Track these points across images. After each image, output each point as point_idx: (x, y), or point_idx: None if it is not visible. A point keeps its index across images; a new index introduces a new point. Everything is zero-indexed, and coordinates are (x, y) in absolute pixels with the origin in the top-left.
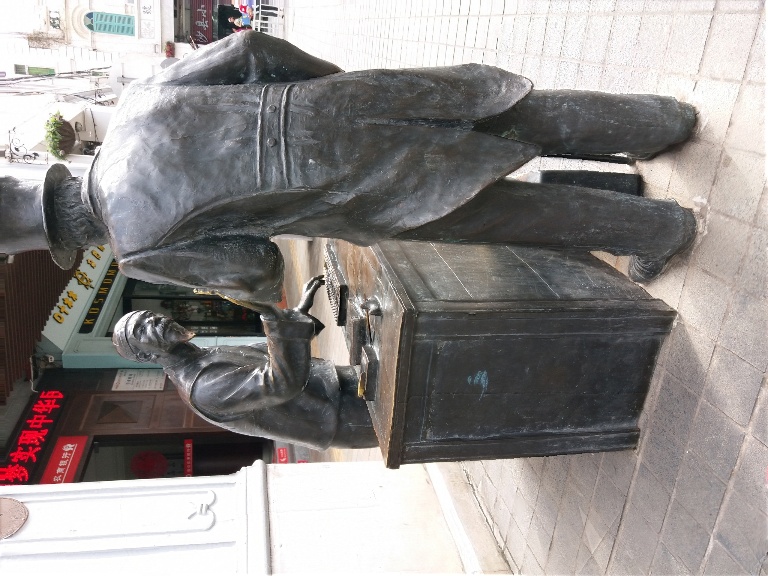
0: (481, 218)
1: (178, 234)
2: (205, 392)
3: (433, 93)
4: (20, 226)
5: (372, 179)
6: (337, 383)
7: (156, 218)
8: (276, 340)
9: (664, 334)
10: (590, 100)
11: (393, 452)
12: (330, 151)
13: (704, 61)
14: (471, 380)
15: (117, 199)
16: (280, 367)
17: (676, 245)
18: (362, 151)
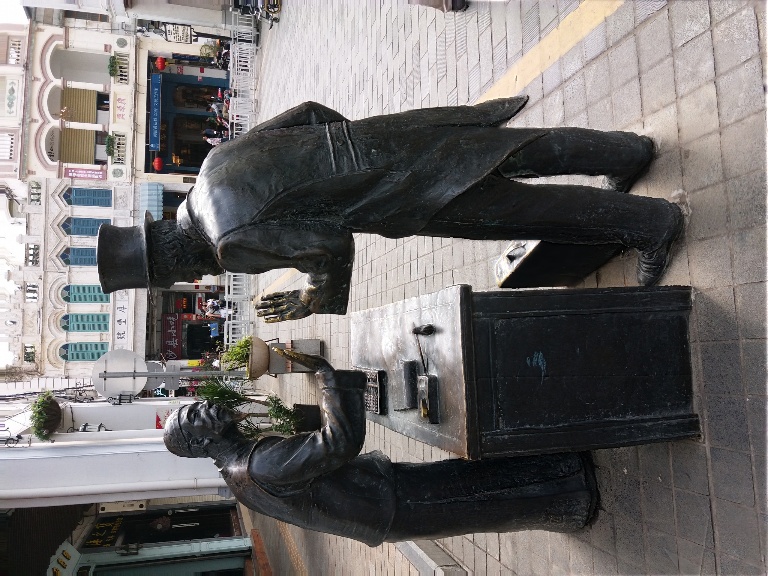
0: (510, 201)
1: (270, 212)
2: (263, 461)
3: (455, 113)
4: (120, 252)
5: (422, 159)
6: (389, 461)
7: (252, 199)
8: (333, 390)
9: (687, 310)
10: (570, 129)
11: (471, 439)
12: (387, 144)
13: (644, 106)
14: (530, 361)
15: (218, 192)
16: (338, 420)
17: (671, 226)
18: (411, 142)
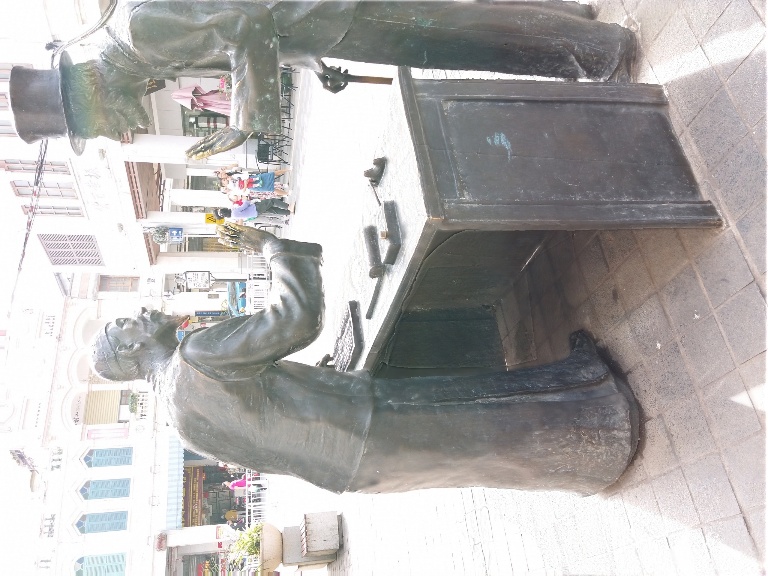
0: (442, 6)
1: None
2: (199, 339)
3: None
4: (34, 80)
5: None
6: (364, 369)
7: None
8: (281, 257)
9: (664, 106)
10: None
11: (429, 198)
12: None
13: None
14: (491, 141)
15: None
16: (289, 286)
17: (622, 38)
18: None
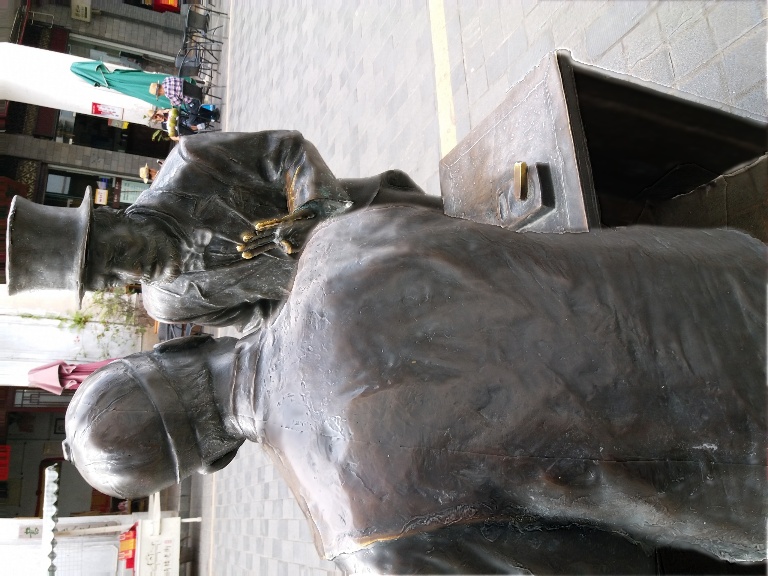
0: None
1: None
2: None
3: None
4: None
5: None
6: None
7: None
8: None
9: None
10: None
11: None
12: None
13: None
14: None
15: None
16: None
17: None
18: None
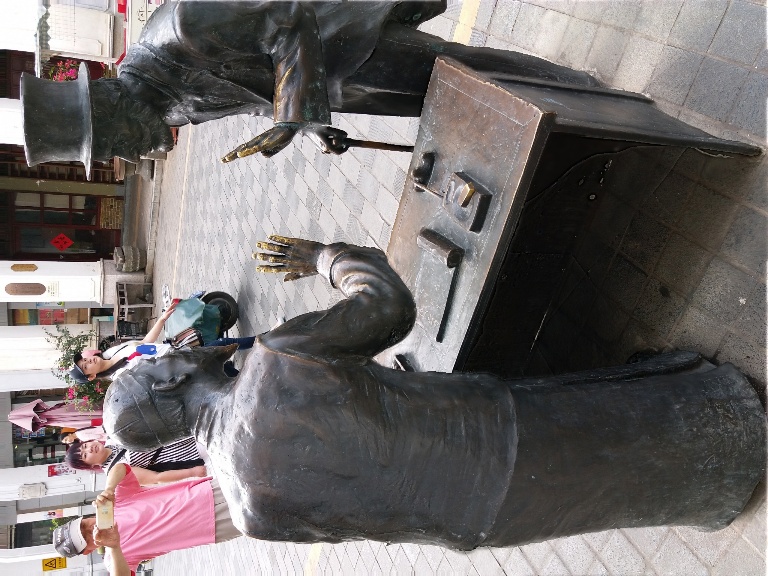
0: None
1: None
2: (281, 330)
3: None
4: None
5: None
6: None
7: None
8: (347, 254)
9: (652, 103)
10: None
11: None
12: None
13: None
14: None
15: None
16: (369, 273)
17: (588, 76)
18: None
